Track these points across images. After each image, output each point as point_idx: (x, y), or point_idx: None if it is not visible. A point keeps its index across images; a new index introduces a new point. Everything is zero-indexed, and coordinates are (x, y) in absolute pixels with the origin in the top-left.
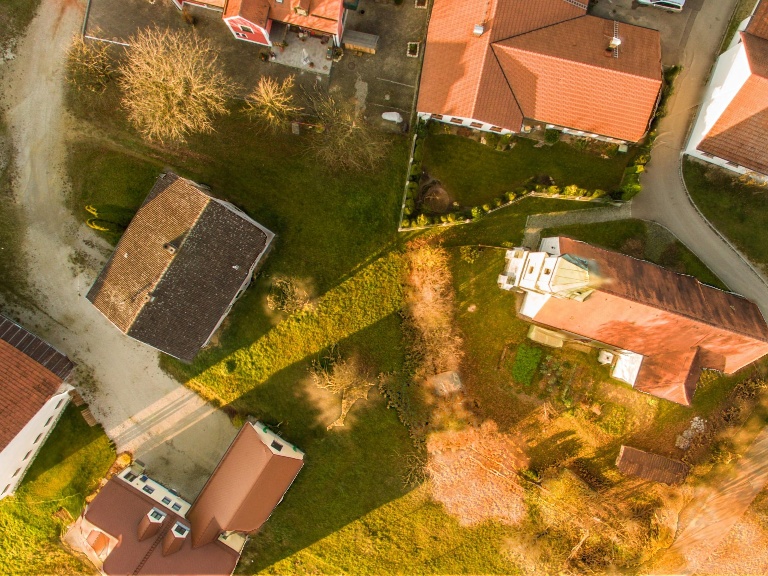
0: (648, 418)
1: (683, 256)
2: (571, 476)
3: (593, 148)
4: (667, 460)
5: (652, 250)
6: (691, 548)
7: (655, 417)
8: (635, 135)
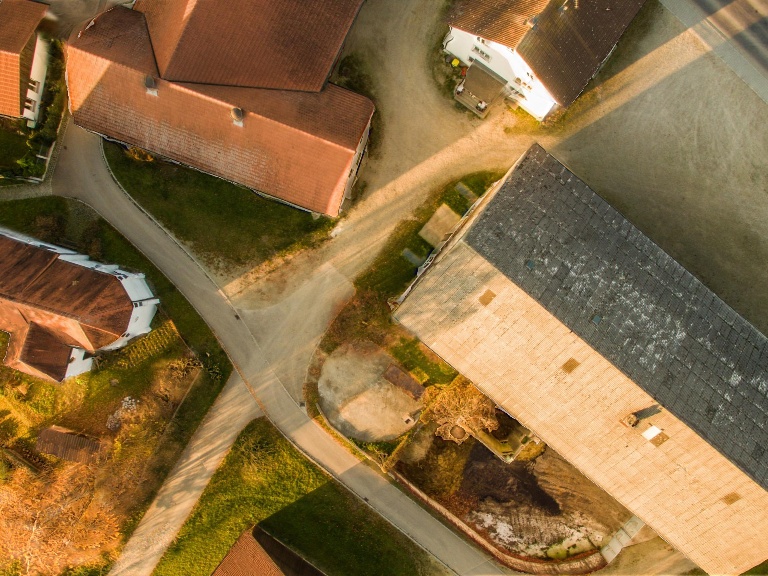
0: (79, 398)
1: (106, 234)
2: (8, 456)
3: (8, 124)
4: (82, 440)
5: (74, 228)
6: (155, 531)
7: (85, 397)
8: (12, 110)
